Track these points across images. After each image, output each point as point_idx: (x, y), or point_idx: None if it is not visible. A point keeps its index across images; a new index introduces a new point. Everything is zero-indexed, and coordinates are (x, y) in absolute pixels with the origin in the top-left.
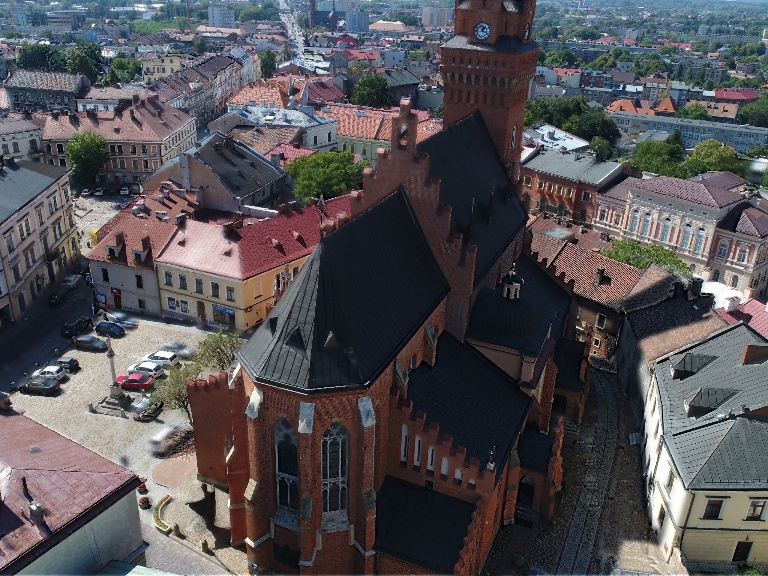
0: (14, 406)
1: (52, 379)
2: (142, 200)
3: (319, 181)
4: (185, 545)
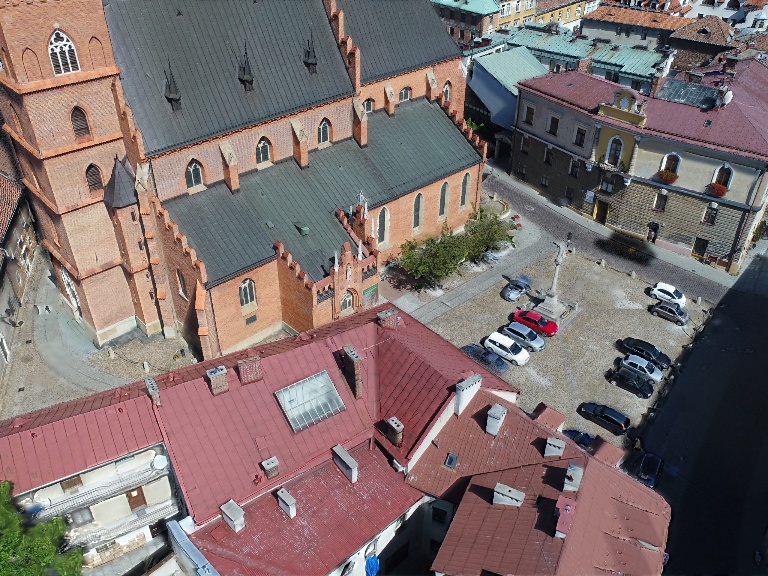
0: (662, 341)
1: (631, 345)
2: (565, 521)
3: (18, 521)
4: (491, 195)
